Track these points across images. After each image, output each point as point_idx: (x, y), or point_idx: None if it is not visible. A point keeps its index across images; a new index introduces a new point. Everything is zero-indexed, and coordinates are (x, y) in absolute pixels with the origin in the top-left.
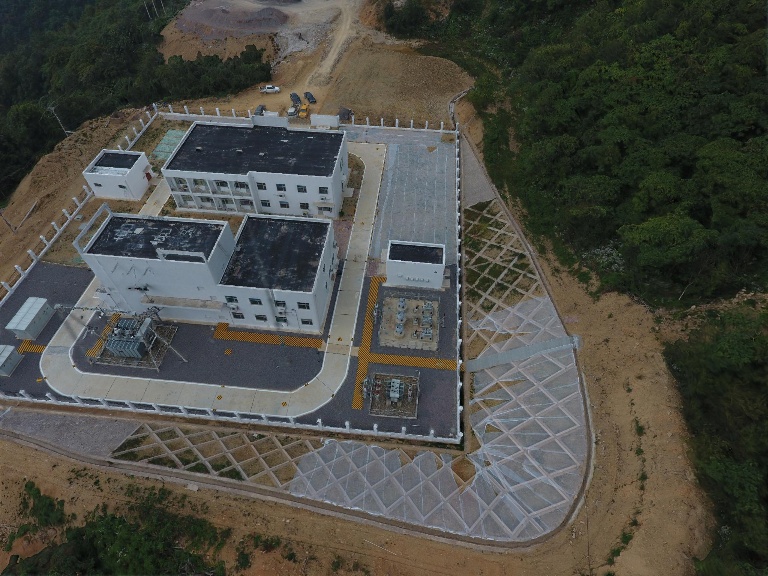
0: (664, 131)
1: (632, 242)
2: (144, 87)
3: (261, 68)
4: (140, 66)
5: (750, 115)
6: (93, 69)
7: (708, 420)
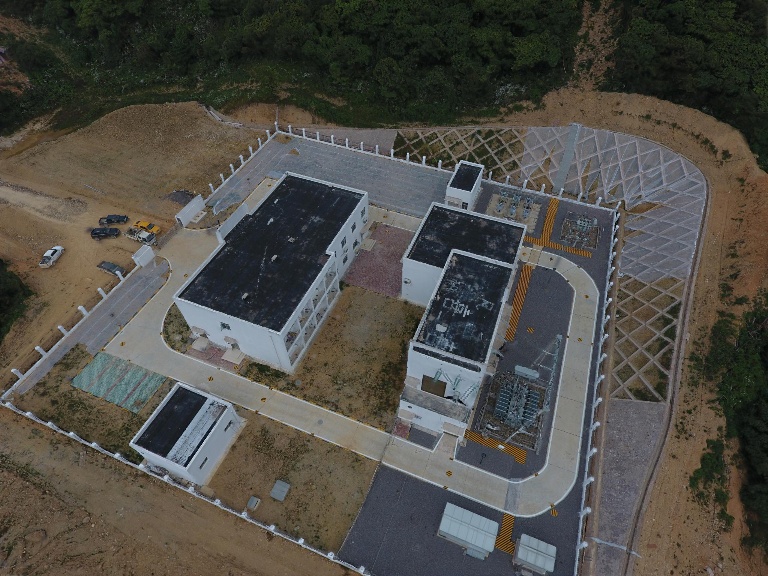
0: None
1: (534, 62)
2: None
3: None
4: None
5: None
6: None
7: None
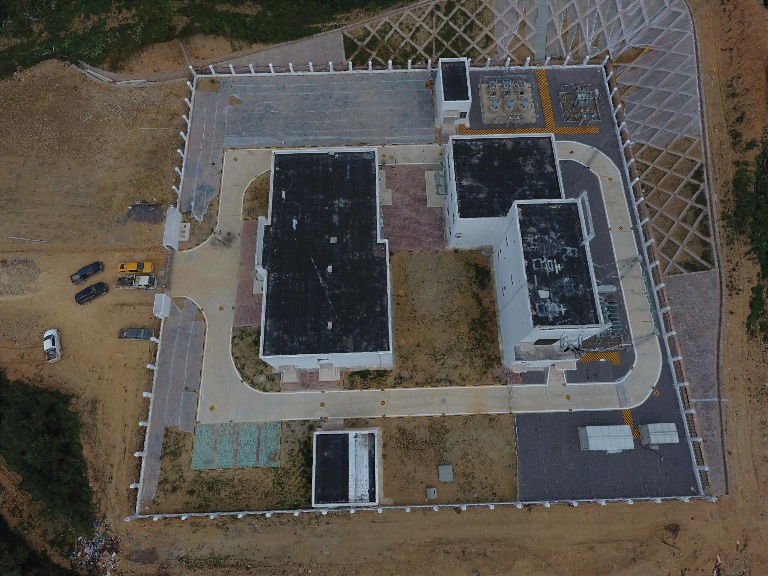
0: None
1: None
2: None
3: None
4: None
5: None
6: None
7: None
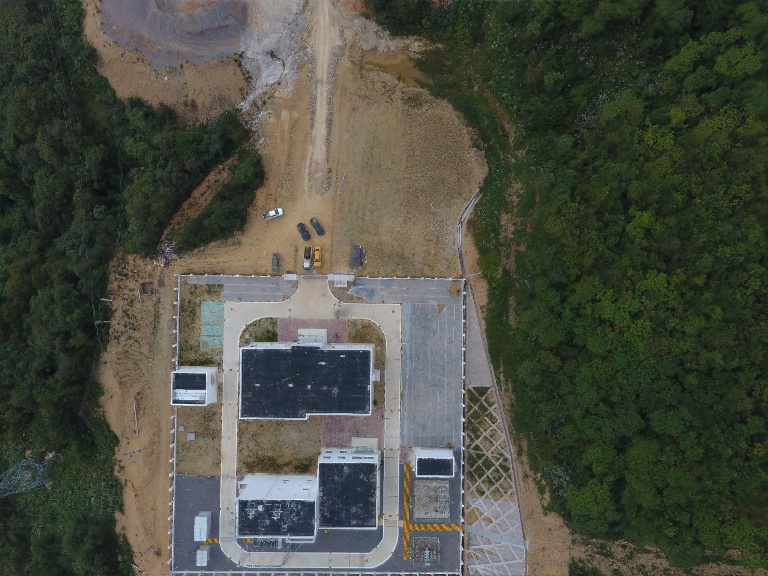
0: (622, 398)
1: None
2: (149, 236)
3: (254, 174)
4: (92, 111)
5: (676, 433)
6: (49, 141)
7: None
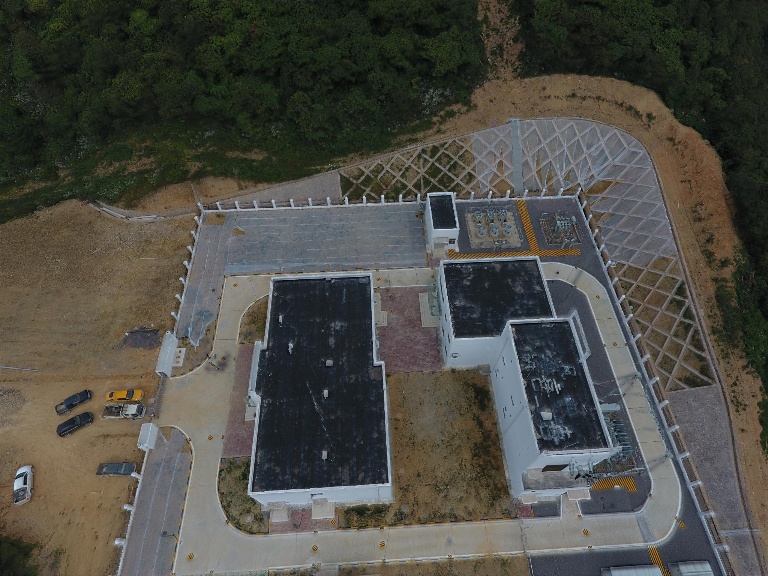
0: None
1: (457, 66)
2: None
3: None
4: None
5: None
6: None
7: (584, 58)
